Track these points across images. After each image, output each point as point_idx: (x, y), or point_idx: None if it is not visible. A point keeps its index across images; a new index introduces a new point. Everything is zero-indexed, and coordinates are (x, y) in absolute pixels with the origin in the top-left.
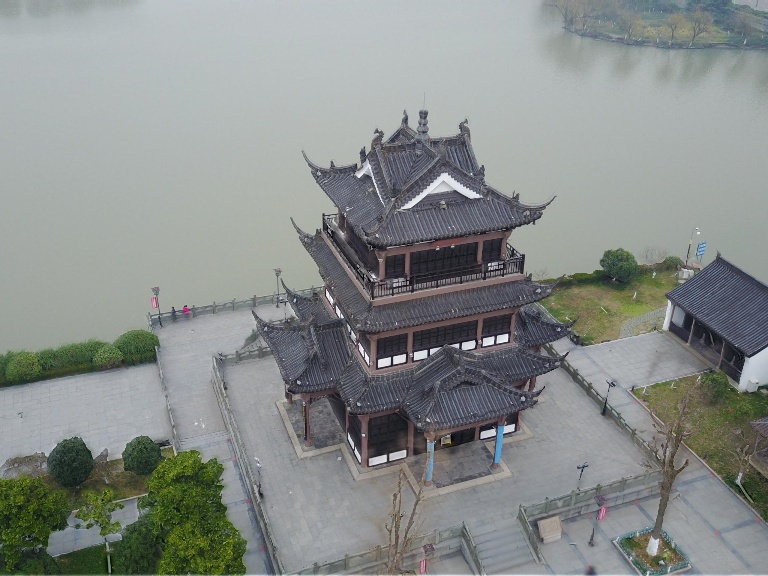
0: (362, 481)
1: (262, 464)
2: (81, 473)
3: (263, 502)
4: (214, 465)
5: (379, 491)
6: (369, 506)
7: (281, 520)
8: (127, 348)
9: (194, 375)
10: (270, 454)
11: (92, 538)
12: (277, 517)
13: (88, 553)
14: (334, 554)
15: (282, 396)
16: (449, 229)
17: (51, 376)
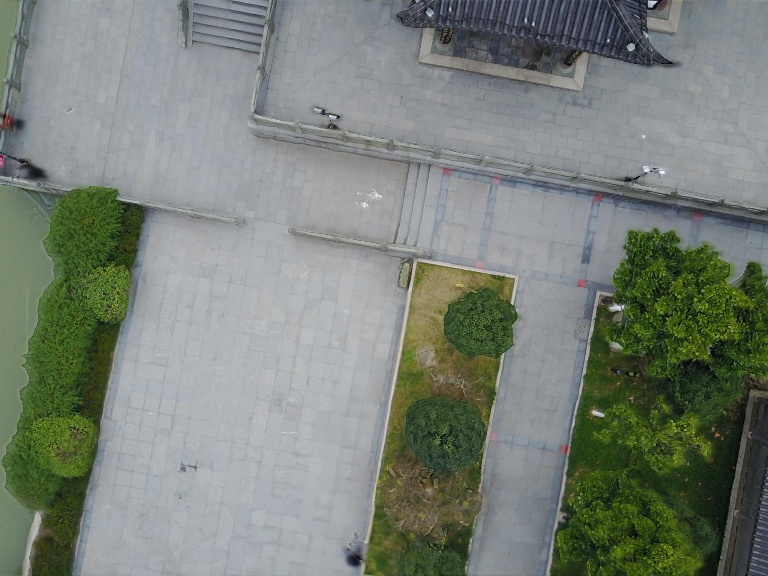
0: (681, 25)
1: (561, 151)
2: None
3: (643, 184)
4: (652, 242)
5: (713, 12)
6: (732, 43)
7: (691, 175)
8: (104, 253)
9: (224, 160)
10: (544, 129)
11: (554, 428)
12: (683, 178)
13: (586, 441)
14: None
15: (407, 45)
16: None
17: (101, 400)
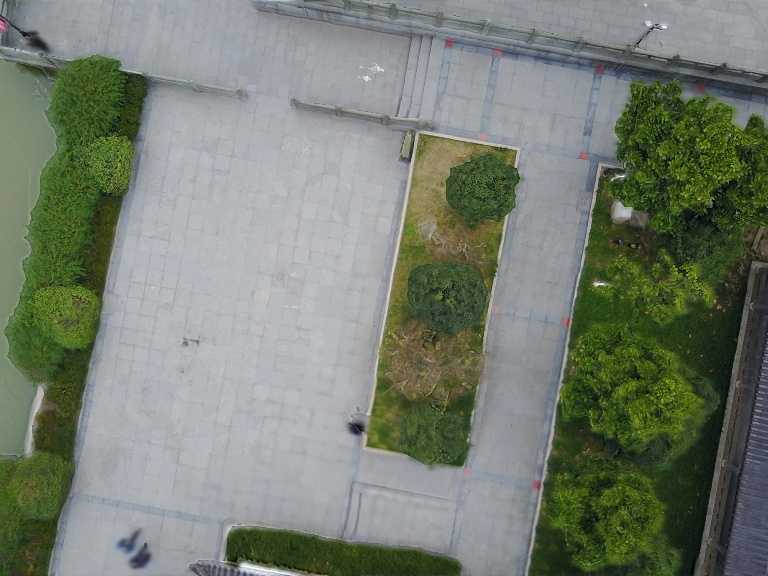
0: None
1: (563, 19)
2: None
3: None
4: (654, 94)
5: None
6: None
7: (693, 43)
8: (106, 122)
9: (226, 34)
10: None
11: (556, 300)
12: (685, 46)
13: (588, 312)
14: None
15: None
16: None
17: (104, 273)
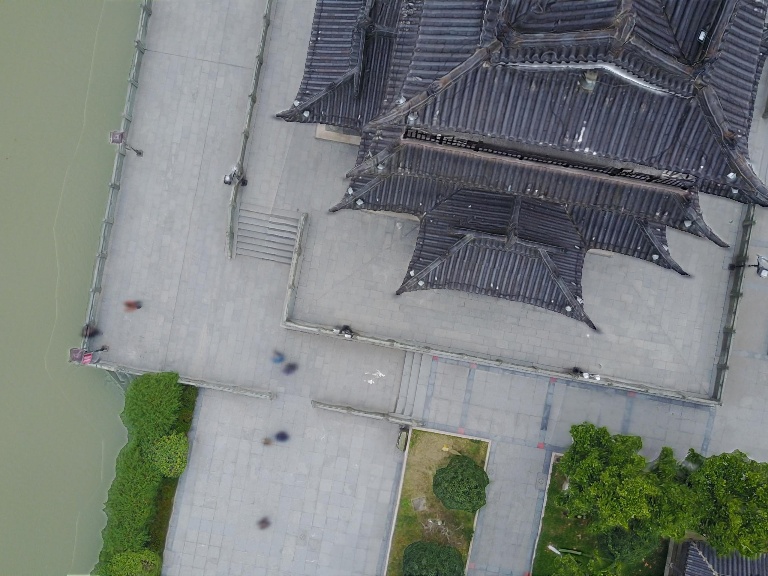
0: None
1: (524, 347)
2: (462, 565)
3: None
4: (589, 435)
5: None
6: None
7: (625, 366)
8: (168, 425)
9: (261, 347)
10: (511, 330)
11: (519, 559)
12: (618, 368)
13: (544, 569)
14: (702, 335)
15: (404, 264)
16: (760, 14)
17: (164, 537)
